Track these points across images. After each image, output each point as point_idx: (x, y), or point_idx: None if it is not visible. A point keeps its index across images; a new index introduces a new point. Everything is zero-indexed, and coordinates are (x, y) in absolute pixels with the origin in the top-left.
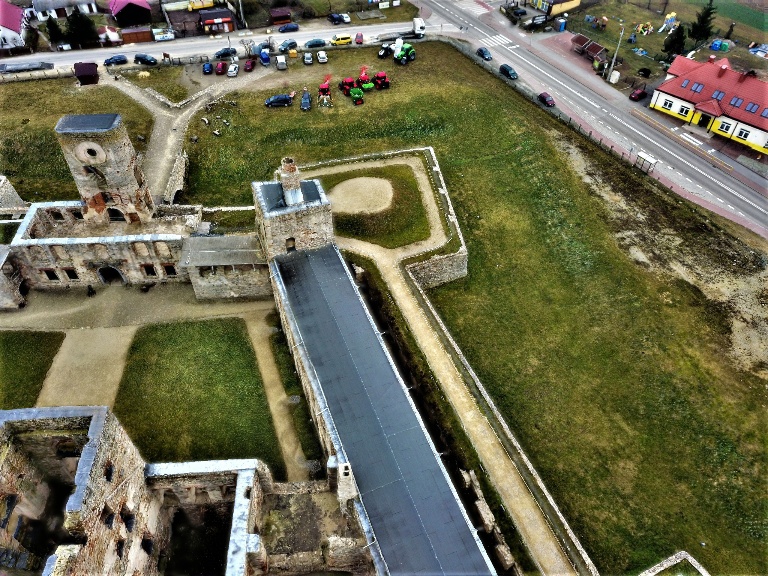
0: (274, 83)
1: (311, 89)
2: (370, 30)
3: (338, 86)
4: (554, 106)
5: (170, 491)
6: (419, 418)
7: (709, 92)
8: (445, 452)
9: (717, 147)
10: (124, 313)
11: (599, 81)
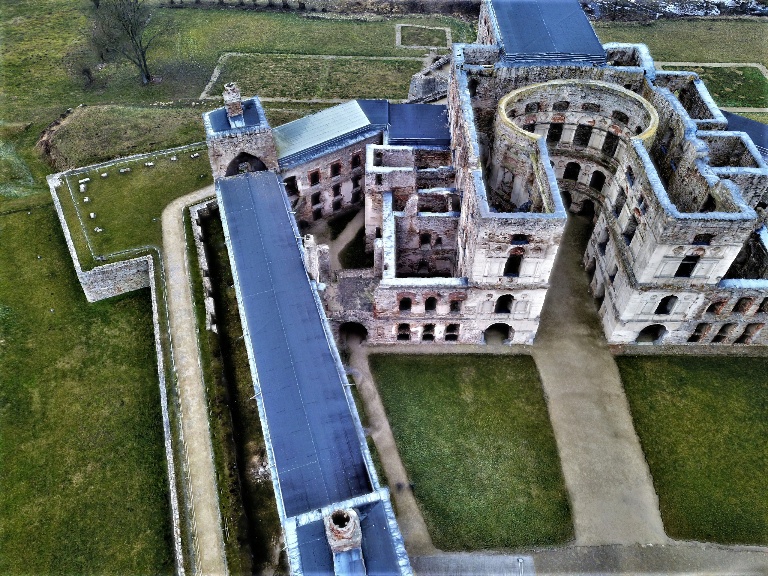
0: None
1: None
2: None
3: None
4: None
5: None
6: (241, 310)
7: None
8: (224, 358)
9: None
10: (607, 569)
11: None
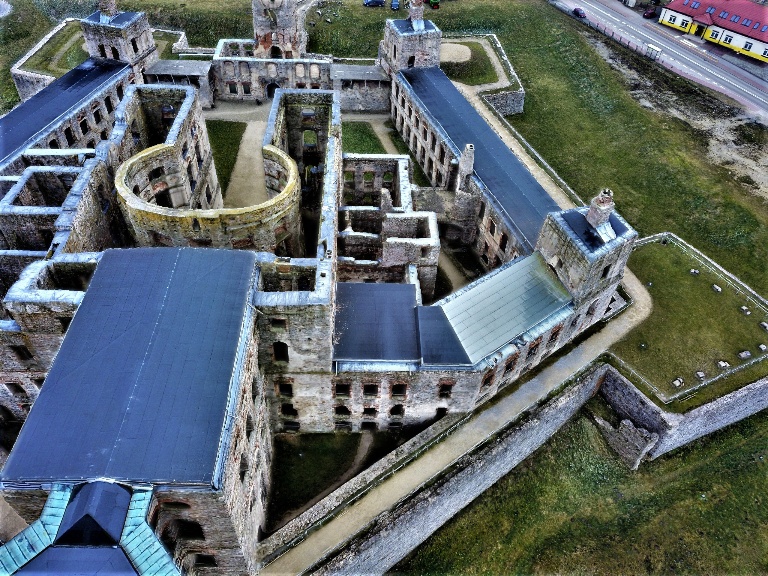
0: None
1: None
2: None
3: None
4: (585, 18)
5: (348, 183)
6: None
7: (704, 8)
8: None
9: (708, 49)
10: None
11: (620, 5)
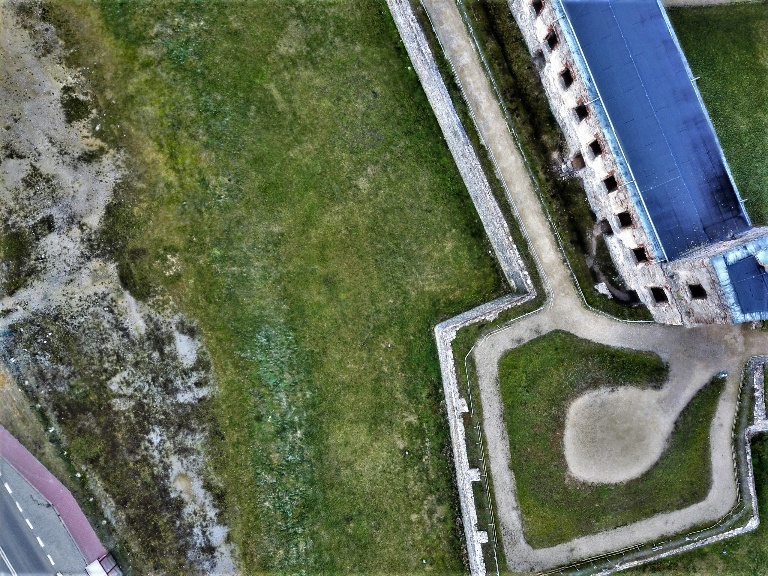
0: None
1: None
2: None
3: None
4: None
5: None
6: None
7: None
8: None
9: None
10: None
11: None
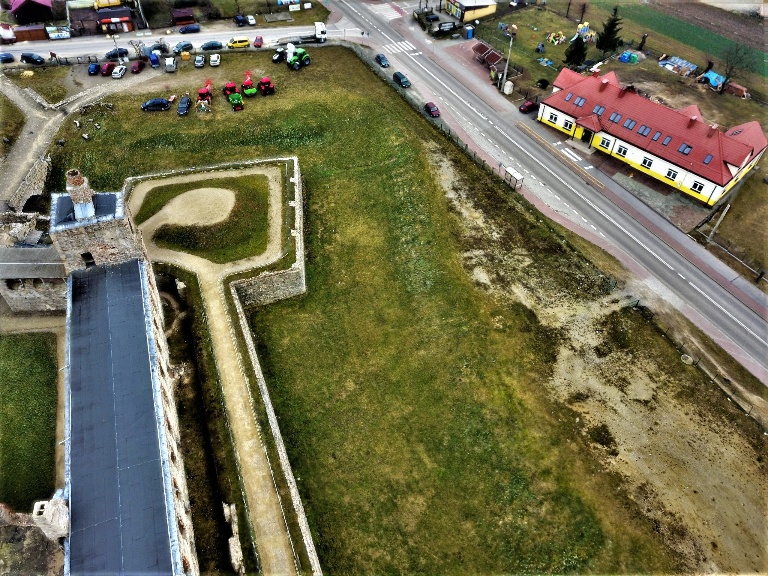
0: (158, 86)
1: (194, 93)
2: (274, 33)
3: (222, 91)
4: (439, 117)
5: None
6: (165, 450)
7: (590, 107)
8: None
9: (595, 164)
10: None
11: (493, 92)
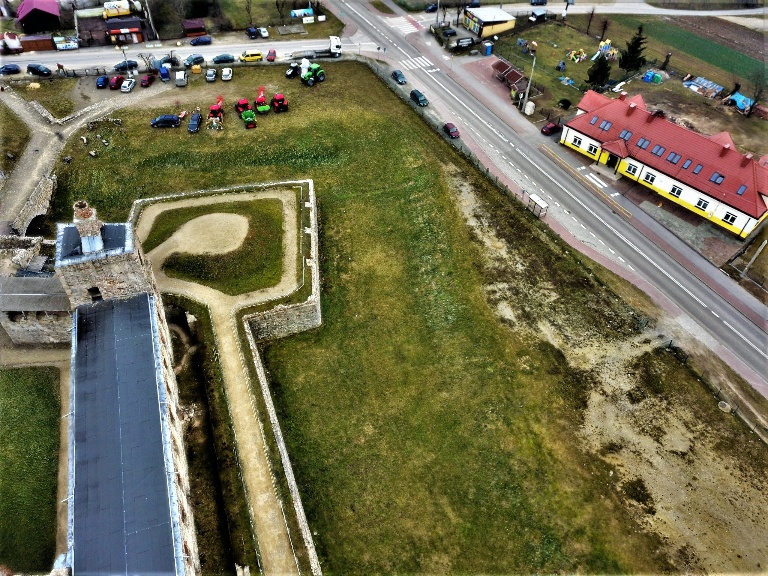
0: (168, 101)
1: (205, 109)
2: (287, 46)
3: (234, 107)
4: (458, 138)
5: None
6: (176, 511)
7: (617, 131)
8: None
9: (622, 190)
10: None
11: (514, 112)
